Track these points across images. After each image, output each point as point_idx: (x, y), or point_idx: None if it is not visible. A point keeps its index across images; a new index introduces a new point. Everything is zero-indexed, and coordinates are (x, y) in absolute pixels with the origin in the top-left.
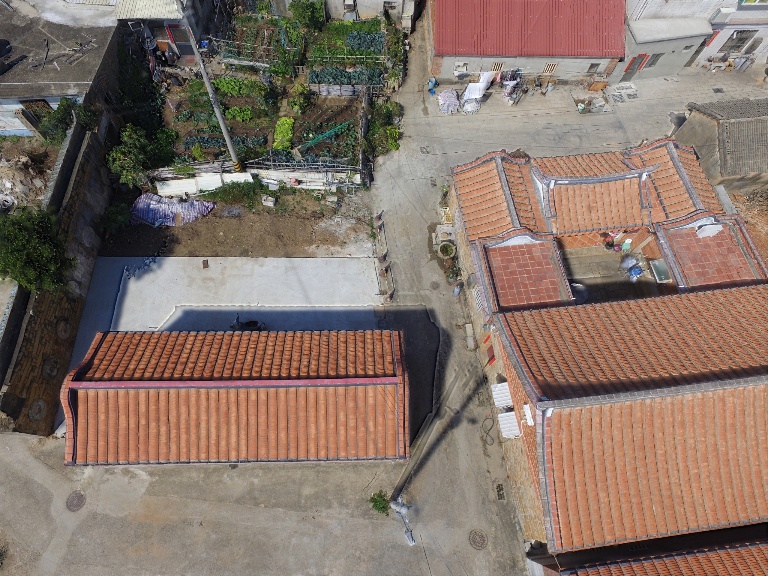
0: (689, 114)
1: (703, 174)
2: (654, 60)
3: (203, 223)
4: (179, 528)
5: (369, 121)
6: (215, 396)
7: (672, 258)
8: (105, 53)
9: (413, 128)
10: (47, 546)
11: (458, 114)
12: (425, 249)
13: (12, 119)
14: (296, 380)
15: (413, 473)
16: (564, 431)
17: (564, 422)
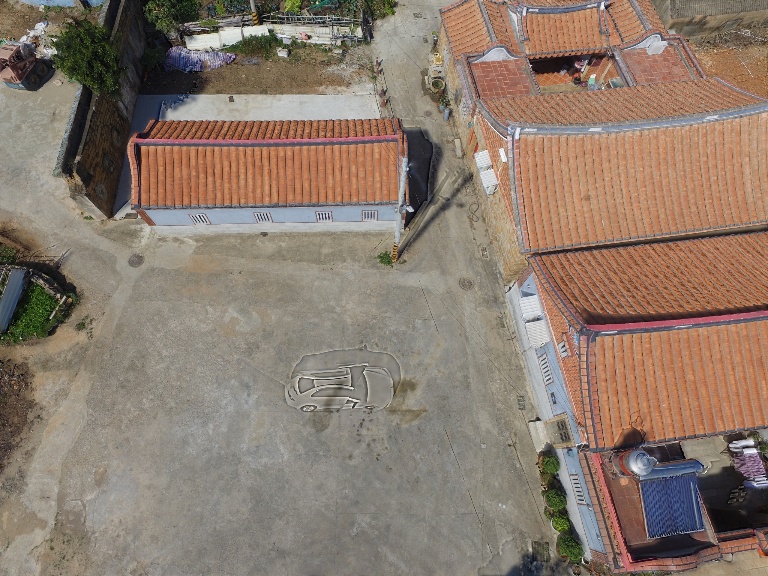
0: None
1: (654, 11)
2: None
3: (227, 69)
4: (222, 276)
5: None
6: (251, 153)
7: (625, 69)
8: None
9: None
10: (115, 290)
11: None
12: (419, 87)
13: None
14: (316, 139)
15: (412, 240)
16: (530, 156)
17: (530, 148)
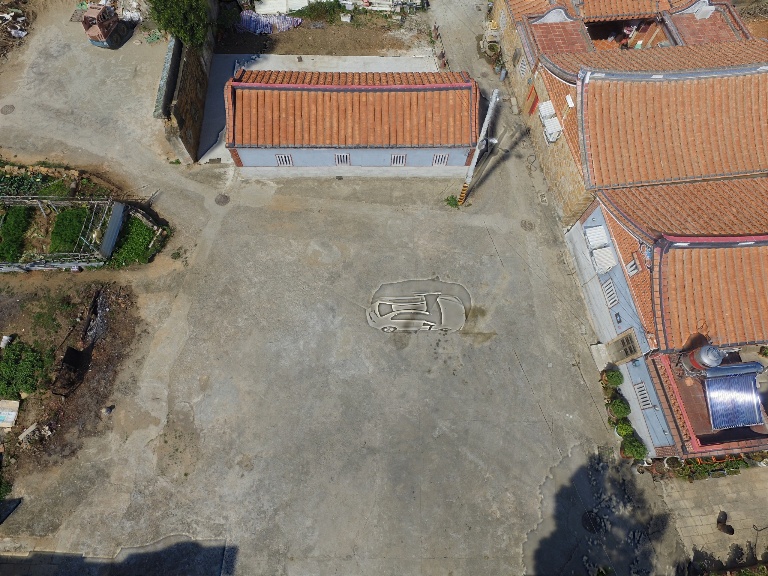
0: None
1: None
2: None
3: (295, 32)
4: (303, 214)
5: None
6: (336, 98)
7: (675, 32)
8: None
9: None
10: (205, 225)
11: None
12: (475, 51)
13: None
14: (396, 85)
15: (476, 186)
16: (597, 100)
17: (597, 92)
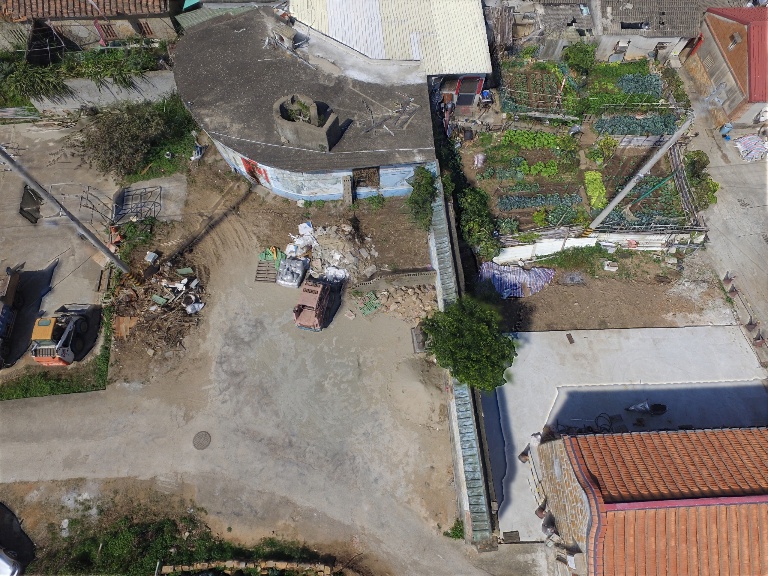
0: None
1: None
2: None
3: (552, 293)
4: None
5: None
6: (745, 512)
7: None
8: (430, 114)
9: (721, 178)
10: None
11: (762, 161)
12: None
13: (330, 185)
14: None
15: None
16: None
17: None
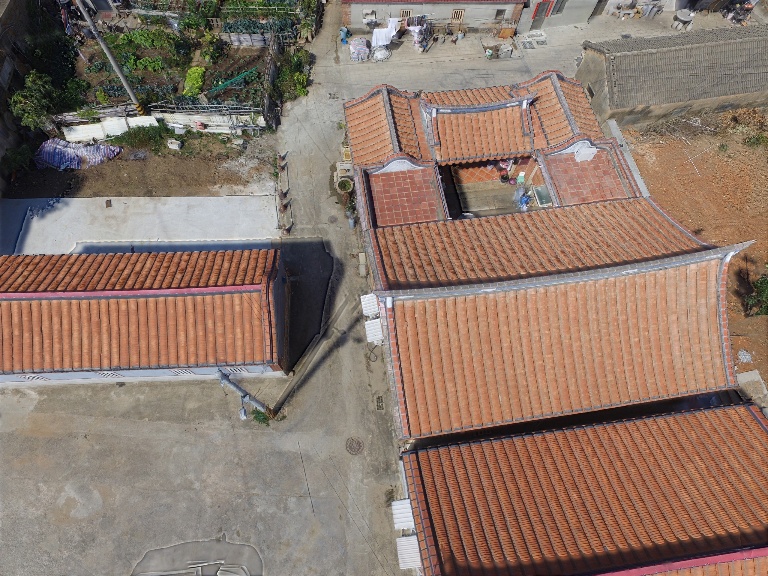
0: (585, 53)
1: (588, 105)
2: (561, 6)
3: (108, 166)
4: (64, 441)
5: (279, 69)
6: (86, 307)
7: (549, 180)
8: (10, 2)
9: (323, 75)
10: None
11: (369, 62)
12: (326, 186)
13: None
14: (164, 290)
15: (296, 388)
16: (408, 323)
17: (408, 314)
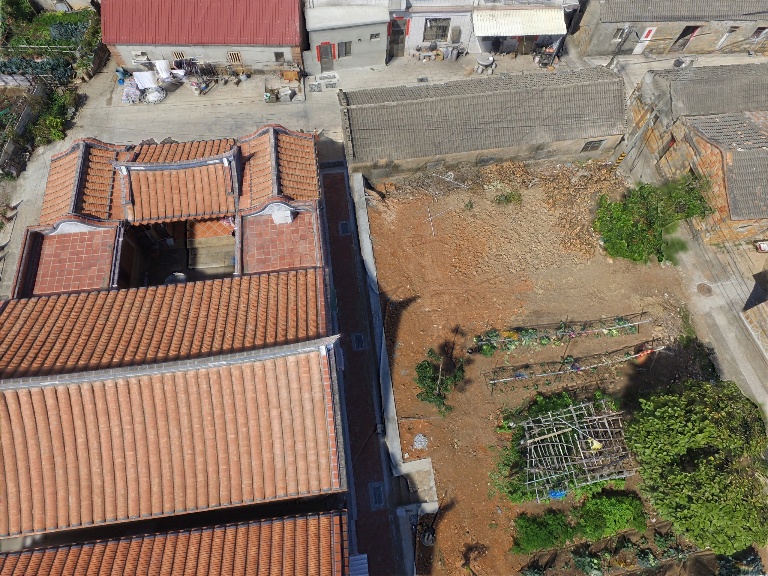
0: None
1: (312, 161)
2: (347, 49)
3: None
4: None
5: (39, 111)
6: None
7: (237, 245)
8: None
9: (89, 118)
10: None
11: (140, 104)
12: None
13: None
14: None
15: None
16: None
17: None
